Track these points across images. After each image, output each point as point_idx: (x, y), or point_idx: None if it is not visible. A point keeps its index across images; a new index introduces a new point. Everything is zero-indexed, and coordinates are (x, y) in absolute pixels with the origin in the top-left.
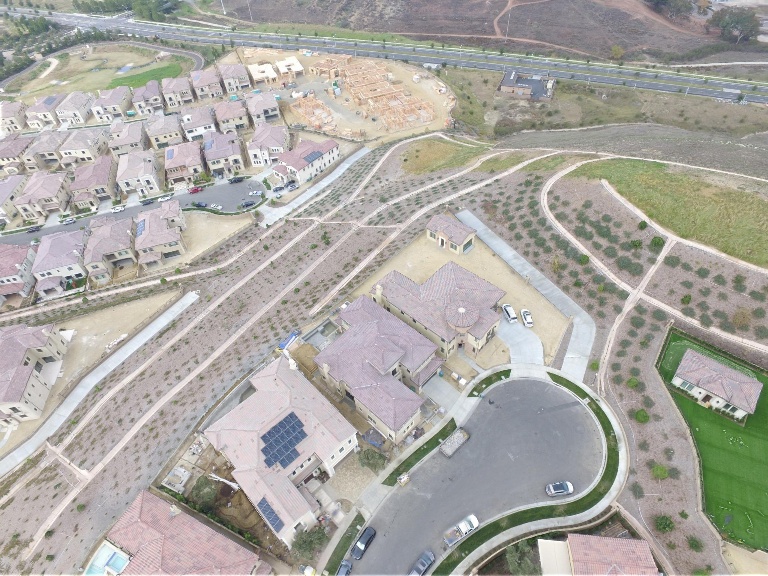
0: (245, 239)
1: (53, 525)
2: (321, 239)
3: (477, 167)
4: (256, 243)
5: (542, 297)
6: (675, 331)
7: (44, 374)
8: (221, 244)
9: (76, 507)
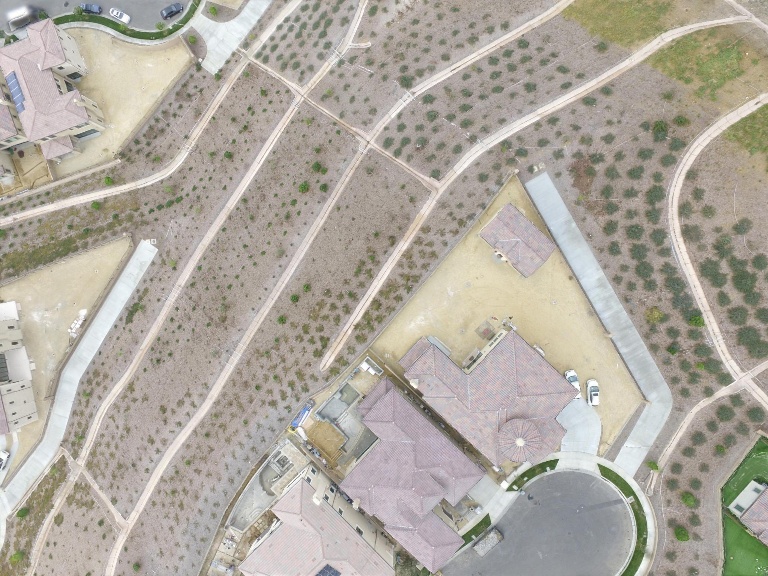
0: (188, 101)
1: (117, 570)
2: (312, 168)
3: (575, 2)
4: (208, 119)
5: (620, 360)
6: (764, 440)
7: (13, 367)
8: (154, 111)
9: (131, 561)
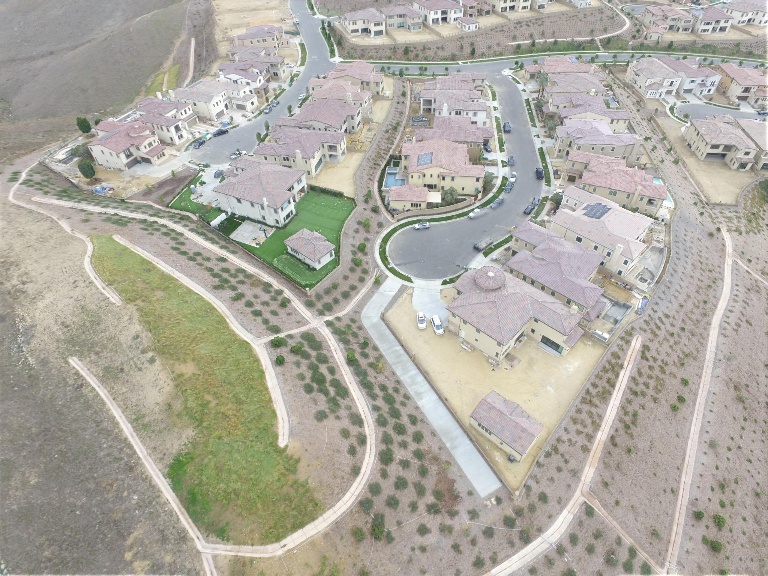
0: None
1: None
2: None
3: None
4: None
5: None
6: None
7: None
8: None
9: None
